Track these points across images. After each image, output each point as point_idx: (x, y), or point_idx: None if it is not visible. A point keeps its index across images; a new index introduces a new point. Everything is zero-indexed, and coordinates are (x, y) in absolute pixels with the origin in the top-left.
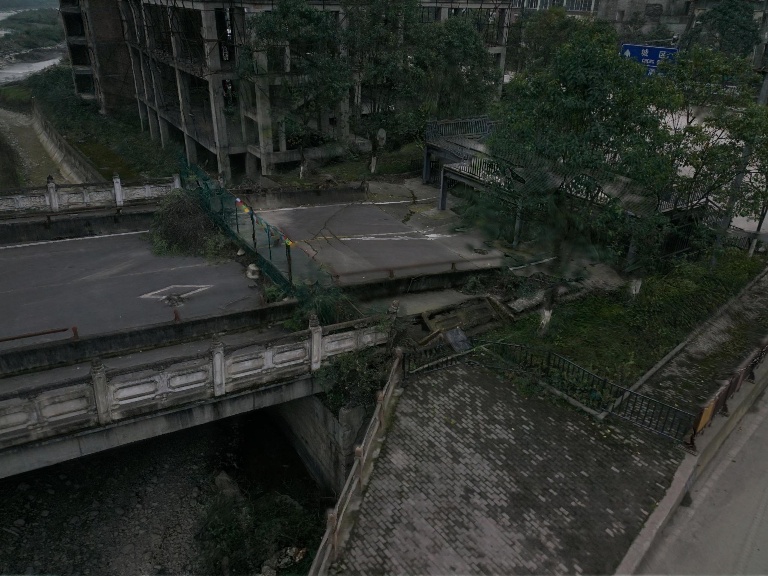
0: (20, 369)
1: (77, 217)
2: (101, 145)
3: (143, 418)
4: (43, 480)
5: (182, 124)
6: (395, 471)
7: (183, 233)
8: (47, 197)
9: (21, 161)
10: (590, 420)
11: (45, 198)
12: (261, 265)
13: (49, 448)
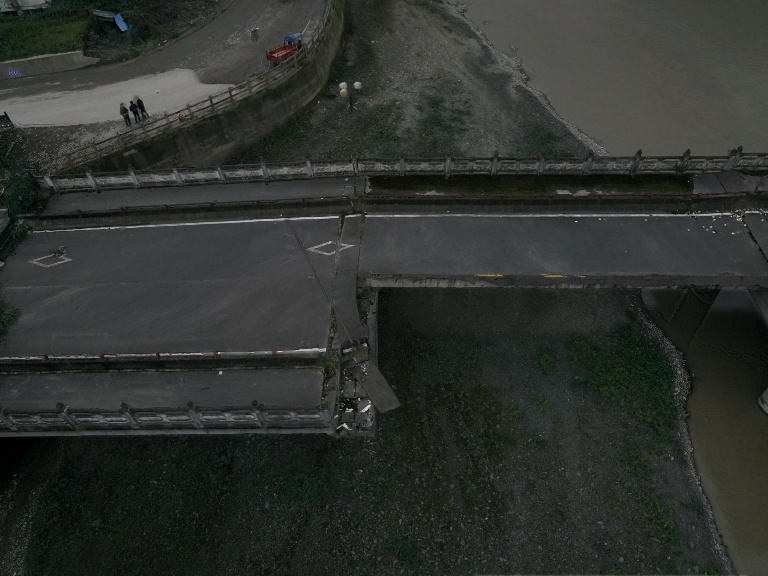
0: None
1: (25, 361)
2: None
3: None
4: None
5: None
6: (84, 157)
7: None
8: None
9: None
10: (17, 145)
11: None
12: None
13: None
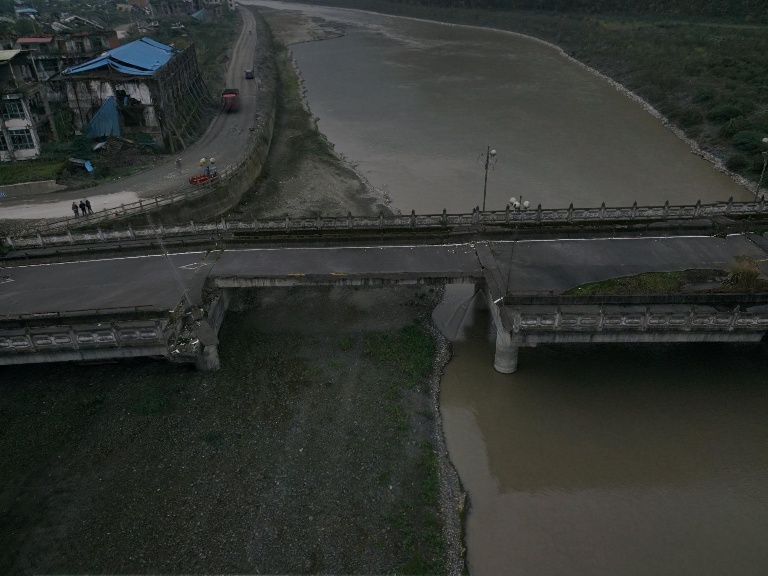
0: None
1: None
2: None
3: None
4: None
5: None
6: None
7: None
8: None
9: None
10: None
11: None
12: None
13: None
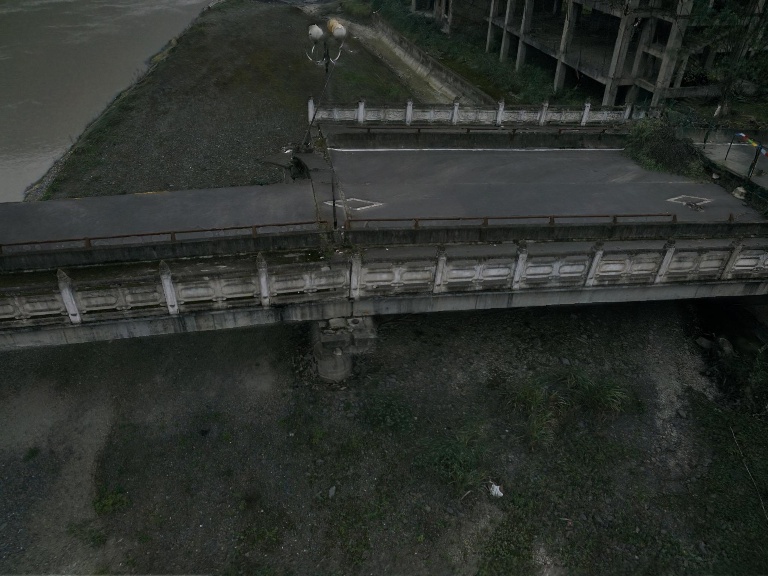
0: (639, 236)
1: (576, 133)
2: (459, 63)
3: (741, 281)
4: (583, 315)
5: (559, 52)
6: None
7: (670, 155)
8: (539, 114)
9: (397, 72)
10: None
11: (537, 114)
12: (753, 189)
13: (687, 288)
